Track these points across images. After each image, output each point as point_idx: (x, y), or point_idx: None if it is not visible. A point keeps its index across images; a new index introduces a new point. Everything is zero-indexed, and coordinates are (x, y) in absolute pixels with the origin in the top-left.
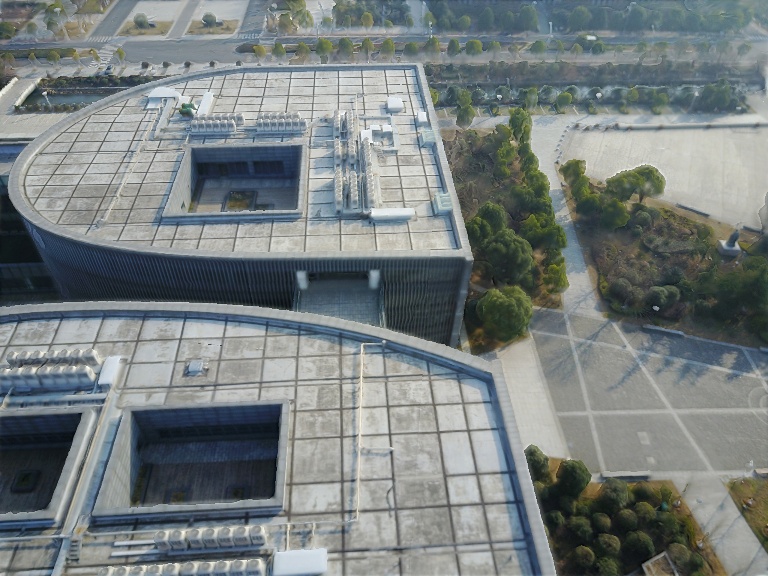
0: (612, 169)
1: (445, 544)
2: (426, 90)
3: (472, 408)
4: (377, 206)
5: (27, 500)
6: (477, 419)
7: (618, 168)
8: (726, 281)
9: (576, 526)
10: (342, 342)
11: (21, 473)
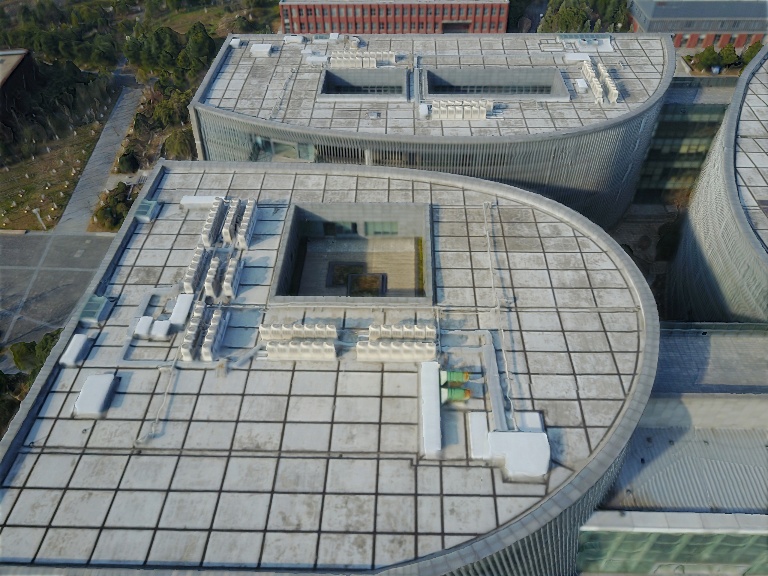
0: None
1: None
2: (10, 434)
3: (218, 97)
4: None
5: None
6: (218, 93)
7: None
8: None
9: None
10: None
11: None
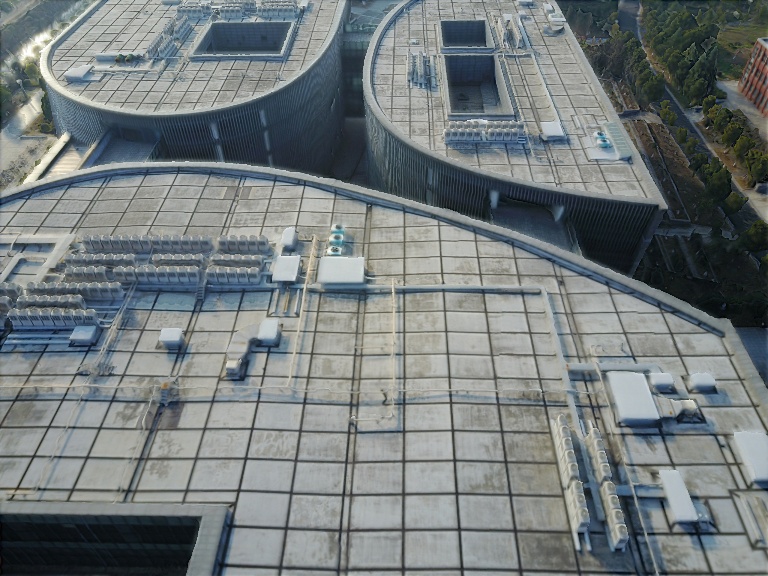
0: None
1: (497, 4)
2: None
3: None
4: None
5: (472, 96)
6: None
7: None
8: None
9: None
10: (401, 16)
11: (459, 97)
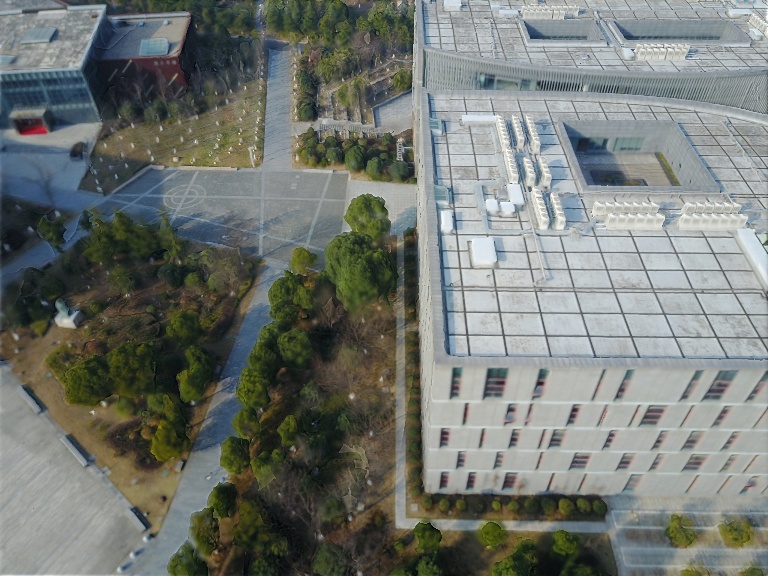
0: (64, 510)
1: None
2: (436, 276)
3: (437, 42)
4: (494, 125)
5: None
6: (435, 39)
7: (51, 514)
8: (151, 231)
9: (363, 147)
10: None
11: None
